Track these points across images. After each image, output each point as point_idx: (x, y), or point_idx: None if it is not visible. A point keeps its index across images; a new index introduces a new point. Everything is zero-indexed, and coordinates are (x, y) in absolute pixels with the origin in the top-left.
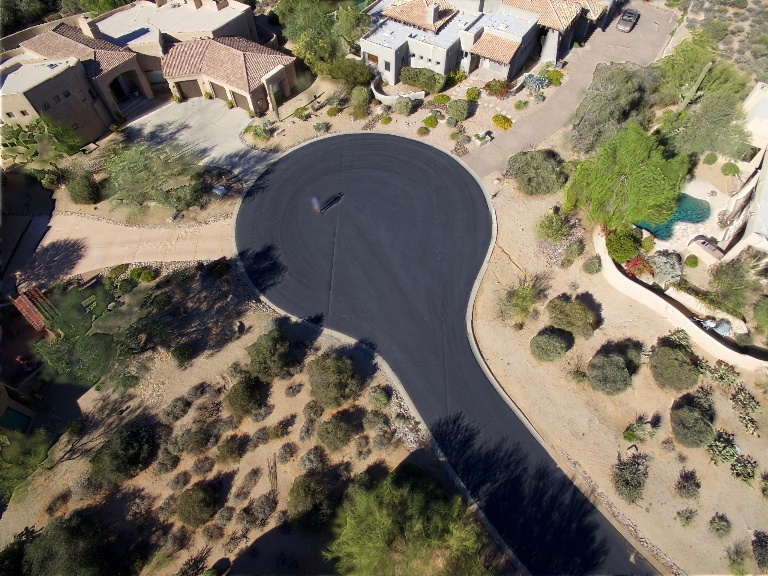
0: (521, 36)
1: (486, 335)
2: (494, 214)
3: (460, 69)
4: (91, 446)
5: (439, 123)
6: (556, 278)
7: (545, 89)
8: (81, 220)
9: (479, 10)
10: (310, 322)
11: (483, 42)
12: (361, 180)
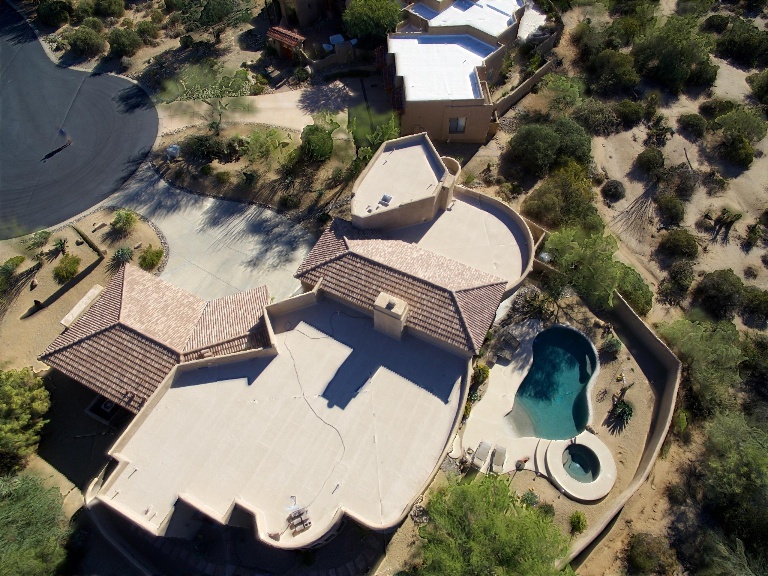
0: None
1: None
2: None
3: None
4: (237, 13)
5: None
6: None
7: None
8: None
9: None
10: (101, 73)
11: None
12: (17, 177)
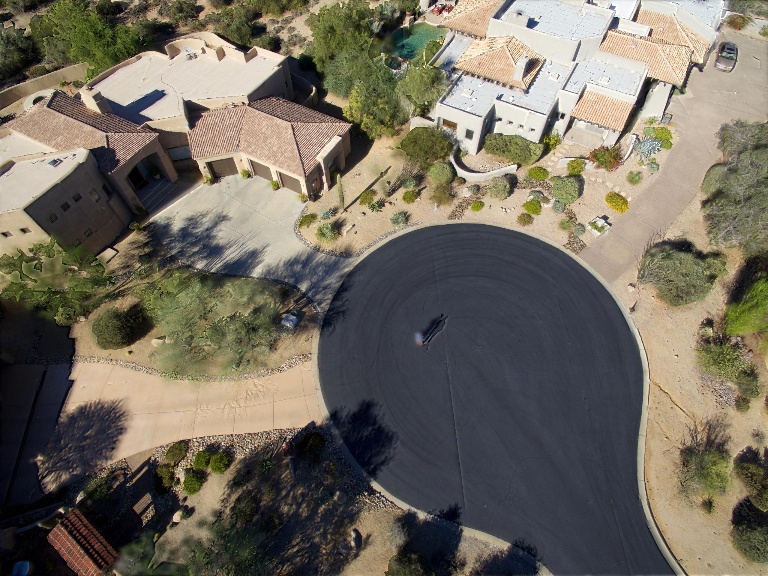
0: (635, 96)
1: (671, 522)
2: (638, 336)
3: (552, 132)
4: None
5: (543, 208)
6: (733, 424)
7: (656, 154)
8: (113, 370)
9: (572, 59)
10: (443, 519)
11: (586, 103)
12: (464, 294)
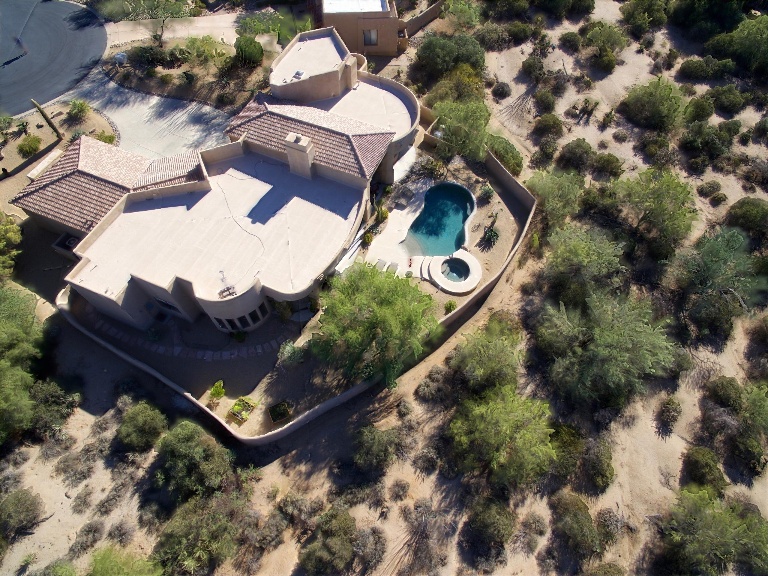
0: None
1: None
2: None
3: None
4: None
5: None
6: None
7: None
8: None
9: None
10: None
11: None
12: None
